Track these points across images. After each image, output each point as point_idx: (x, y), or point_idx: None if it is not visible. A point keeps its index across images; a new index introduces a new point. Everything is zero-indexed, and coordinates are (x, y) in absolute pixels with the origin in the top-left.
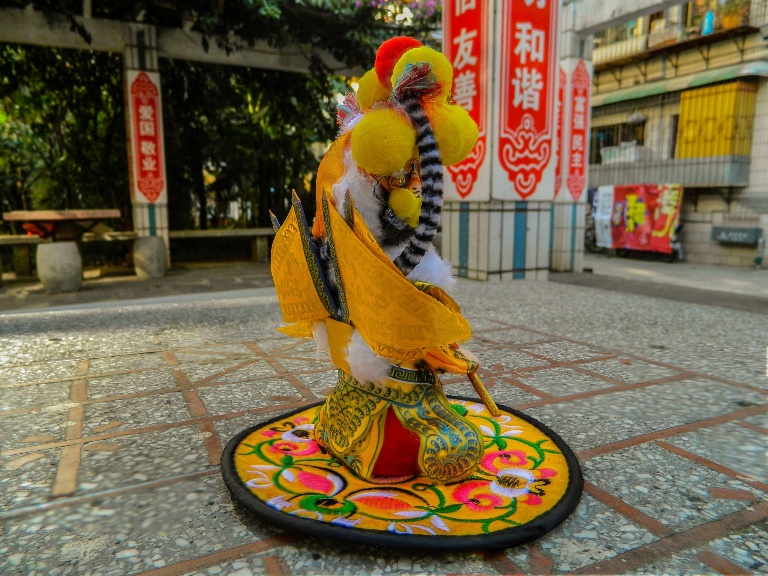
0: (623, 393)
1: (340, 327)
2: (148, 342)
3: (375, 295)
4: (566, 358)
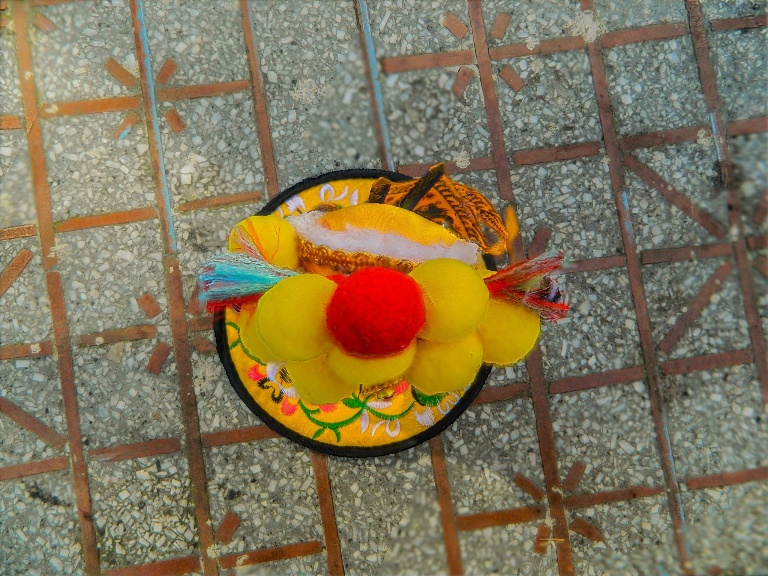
0: None
1: None
2: None
3: None
4: None
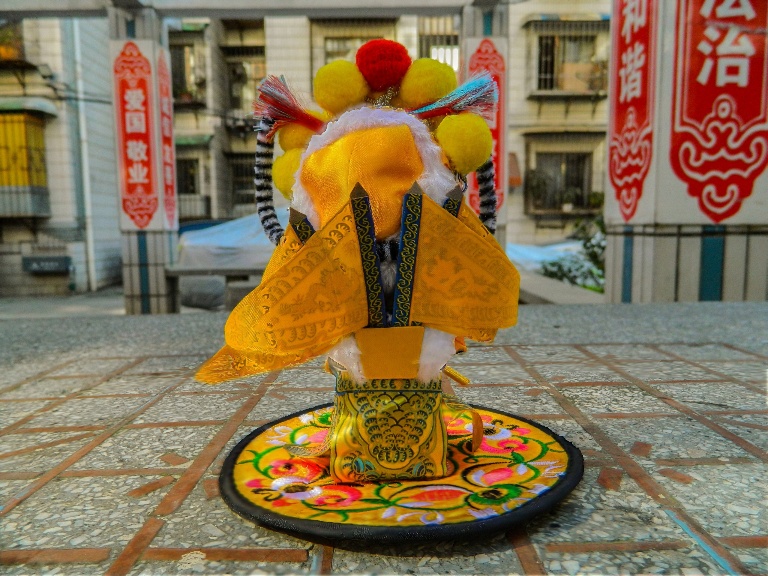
0: None
1: (398, 332)
2: None
3: (488, 284)
4: None
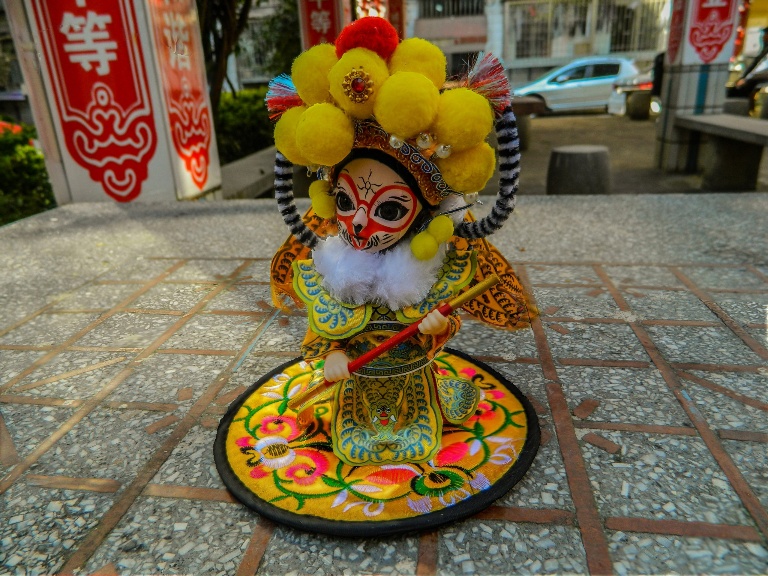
0: None
1: None
2: None
3: None
4: None
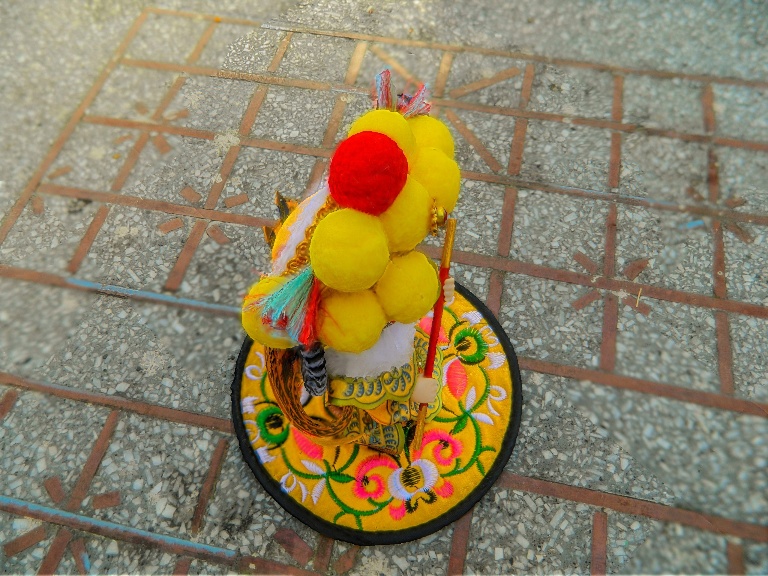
0: (697, 411)
1: None
2: (361, 6)
3: None
4: (747, 290)
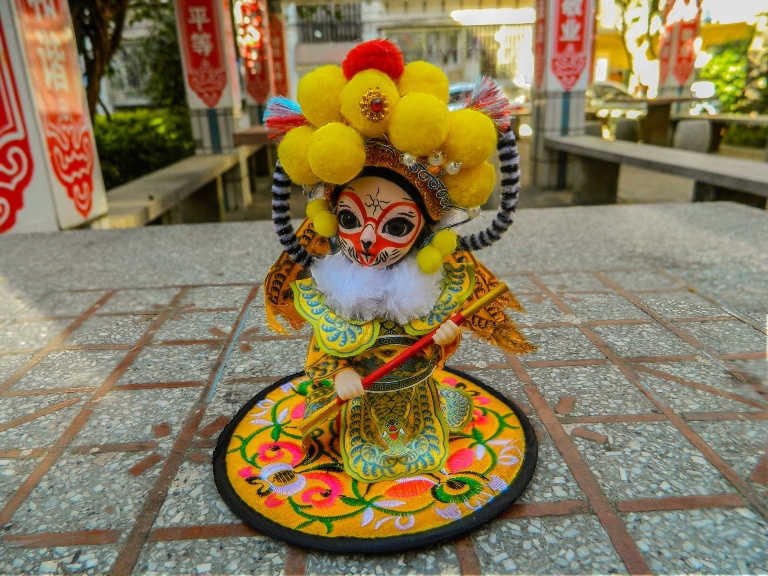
0: None
1: None
2: None
3: None
4: None
